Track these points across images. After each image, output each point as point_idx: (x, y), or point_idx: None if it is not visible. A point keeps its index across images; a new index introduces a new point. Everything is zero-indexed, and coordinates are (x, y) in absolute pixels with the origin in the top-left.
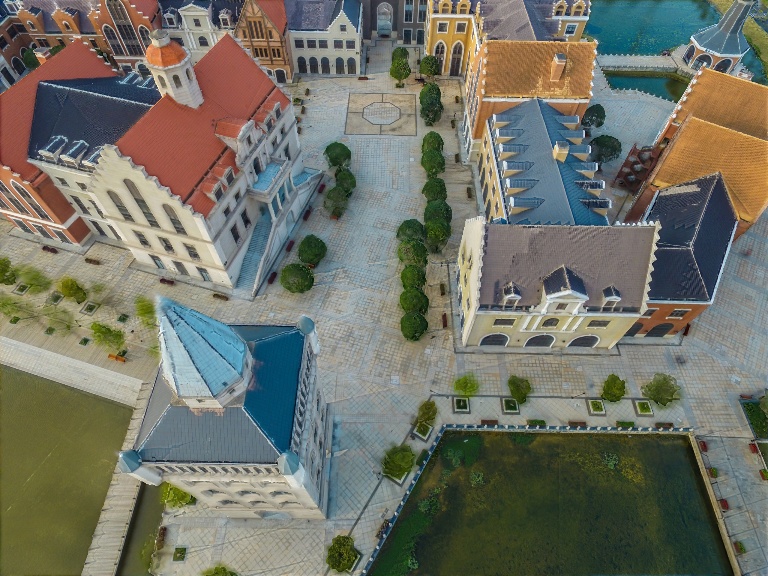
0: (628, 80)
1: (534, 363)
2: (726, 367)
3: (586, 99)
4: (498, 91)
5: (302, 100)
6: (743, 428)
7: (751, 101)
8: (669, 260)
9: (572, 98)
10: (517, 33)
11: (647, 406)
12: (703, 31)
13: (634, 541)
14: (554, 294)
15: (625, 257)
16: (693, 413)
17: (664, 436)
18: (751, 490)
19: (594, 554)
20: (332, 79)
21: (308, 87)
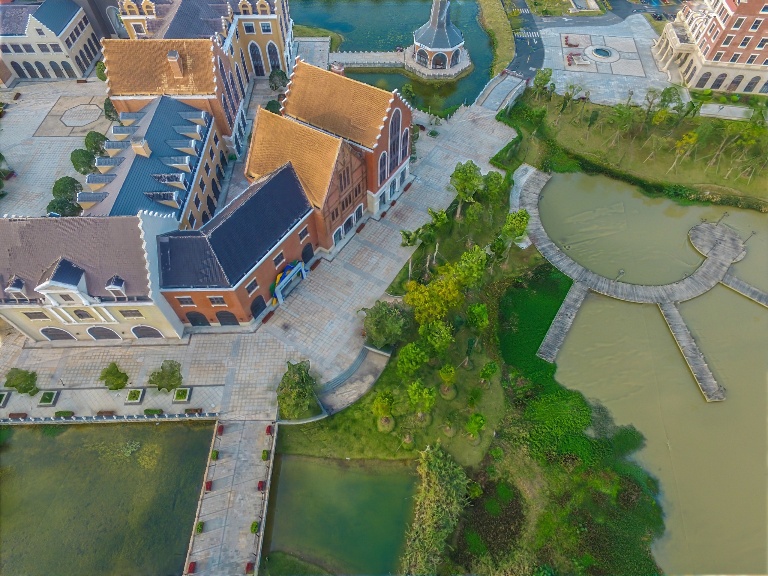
0: (354, 76)
1: (97, 355)
2: (288, 352)
3: (213, 95)
4: (125, 89)
5: (7, 104)
6: (272, 411)
7: (336, 92)
8: (186, 248)
9: (200, 94)
10: (162, 32)
11: (184, 393)
12: (421, 27)
13: (112, 526)
14: (39, 285)
15: (120, 247)
16: (230, 398)
17: (197, 422)
18: (246, 471)
19: (65, 541)
20: (51, 83)
21: (22, 91)
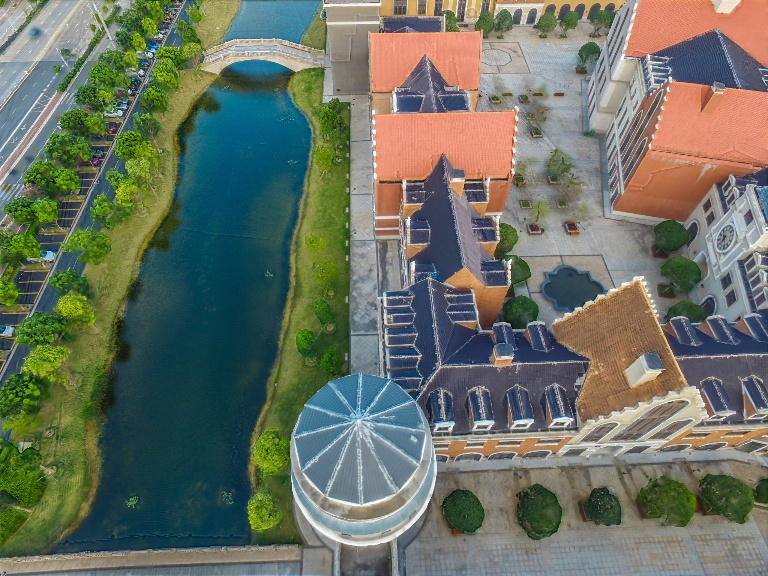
0: None
1: None
2: None
3: None
4: None
5: None
6: None
7: None
8: None
9: None
10: None
11: None
12: None
13: None
14: None
15: None
16: None
17: None
18: None
19: None
20: None
21: None
